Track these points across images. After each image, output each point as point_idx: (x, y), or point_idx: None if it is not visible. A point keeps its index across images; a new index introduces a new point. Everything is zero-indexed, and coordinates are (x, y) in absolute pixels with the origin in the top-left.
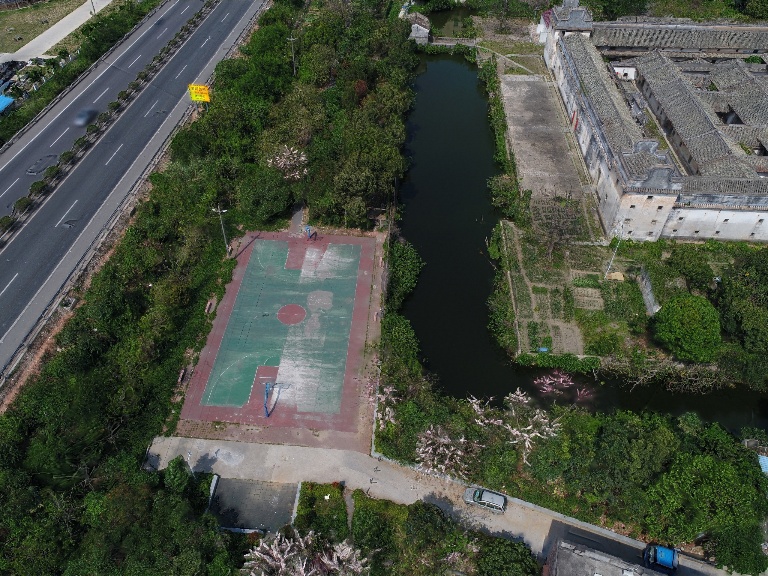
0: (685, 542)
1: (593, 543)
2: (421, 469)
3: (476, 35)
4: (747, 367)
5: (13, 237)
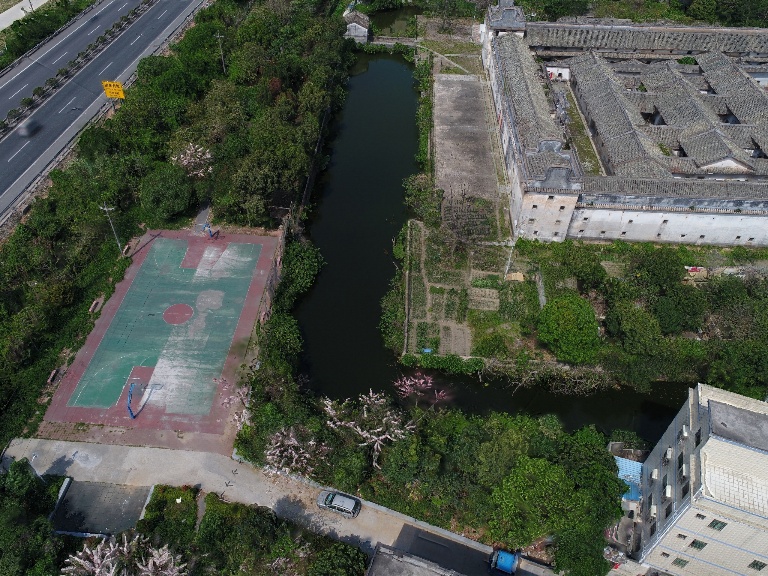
0: (533, 546)
1: (441, 547)
2: (266, 472)
3: (418, 34)
4: (630, 369)
5: None
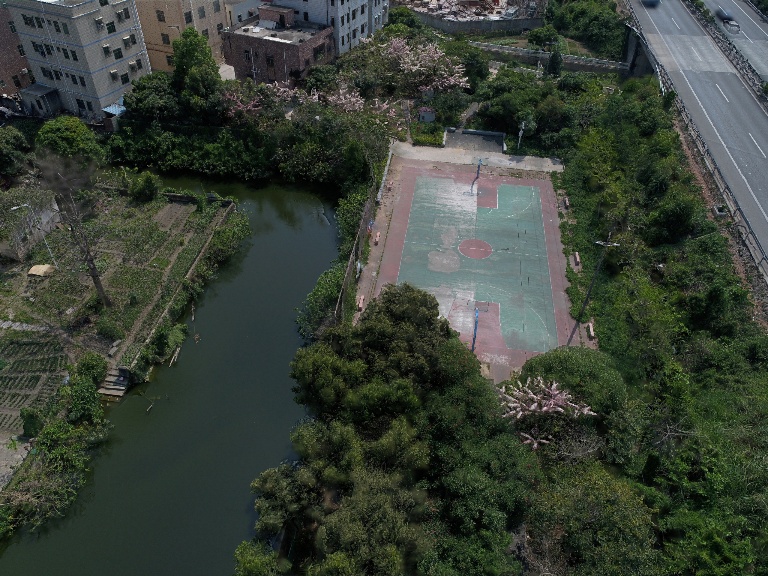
0: None
1: None
2: (362, 100)
3: None
4: None
5: None
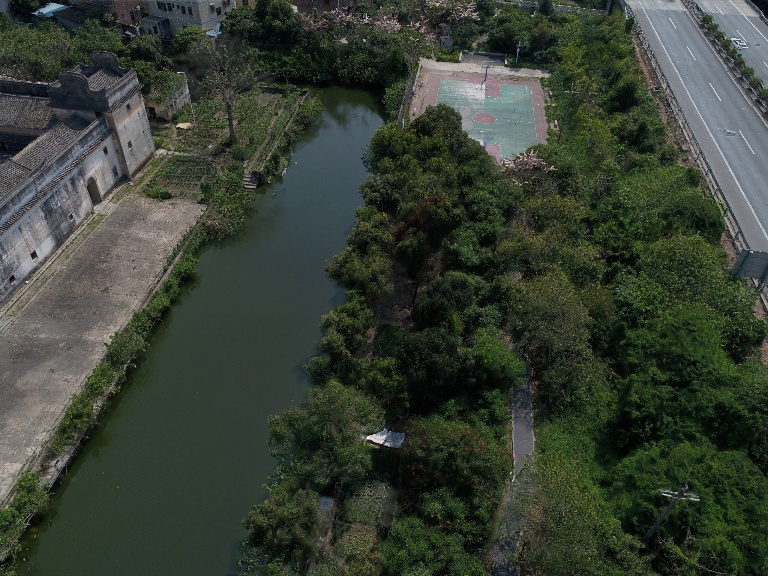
0: None
1: None
2: (399, 25)
3: None
4: None
5: (767, 123)
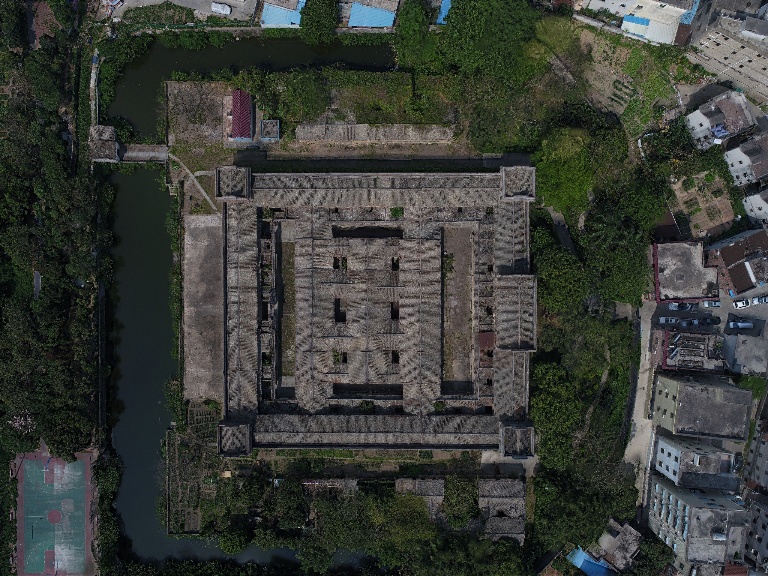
0: None
1: None
2: None
3: (169, 128)
4: None
5: None
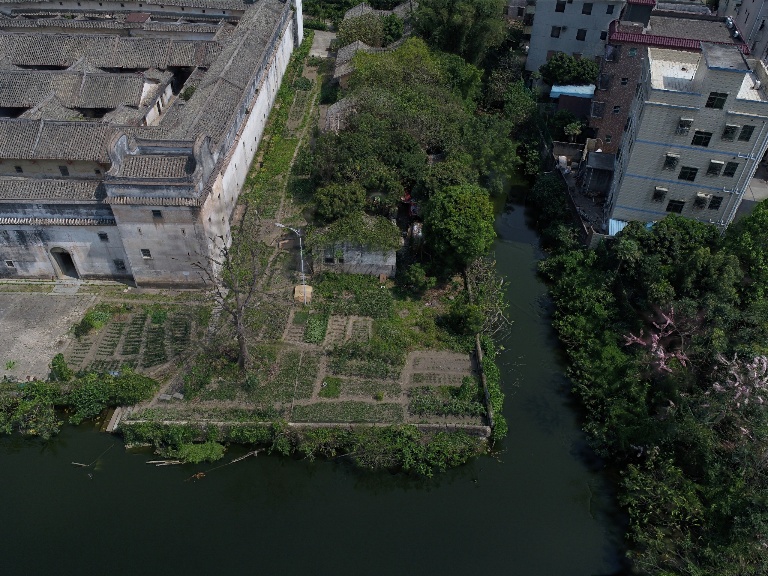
0: None
1: None
2: None
3: None
4: None
5: None
